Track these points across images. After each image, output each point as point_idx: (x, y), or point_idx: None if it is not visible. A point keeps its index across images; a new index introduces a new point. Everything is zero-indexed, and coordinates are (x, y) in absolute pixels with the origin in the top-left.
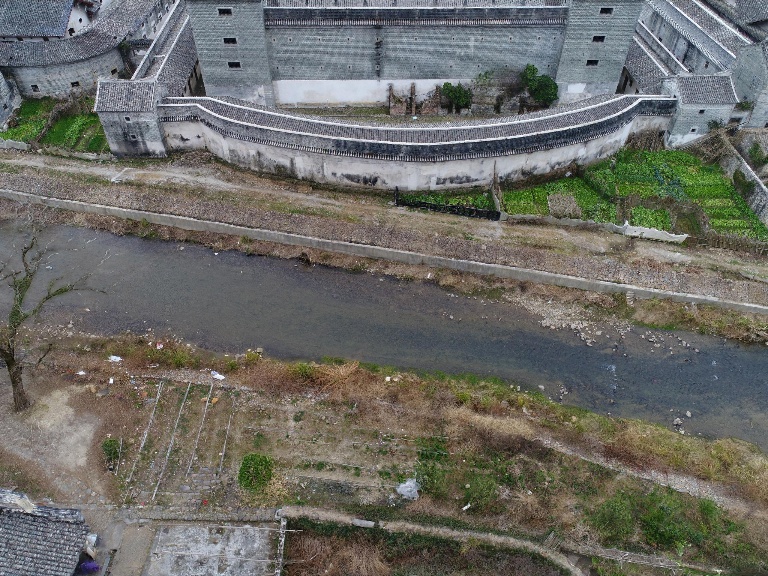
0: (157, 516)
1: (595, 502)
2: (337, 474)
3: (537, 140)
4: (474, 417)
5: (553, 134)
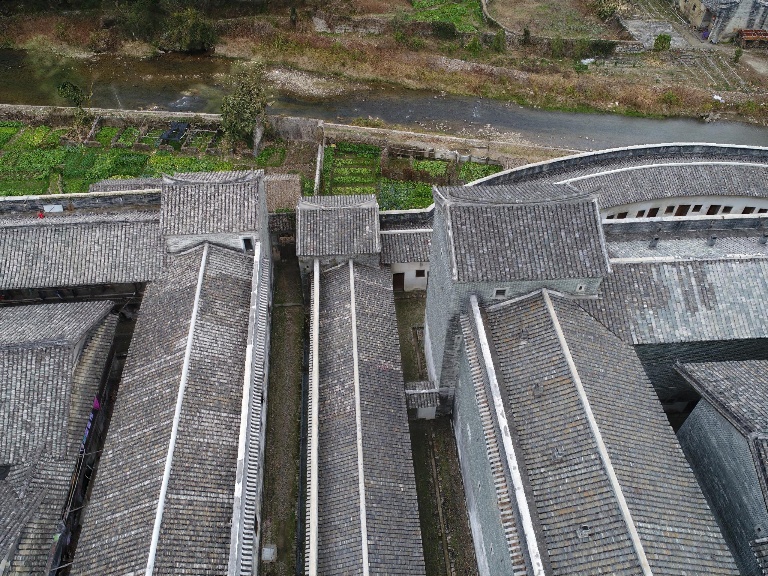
0: (695, 47)
1: (502, 56)
2: (625, 65)
3: (560, 165)
4: (563, 80)
5: (544, 165)
